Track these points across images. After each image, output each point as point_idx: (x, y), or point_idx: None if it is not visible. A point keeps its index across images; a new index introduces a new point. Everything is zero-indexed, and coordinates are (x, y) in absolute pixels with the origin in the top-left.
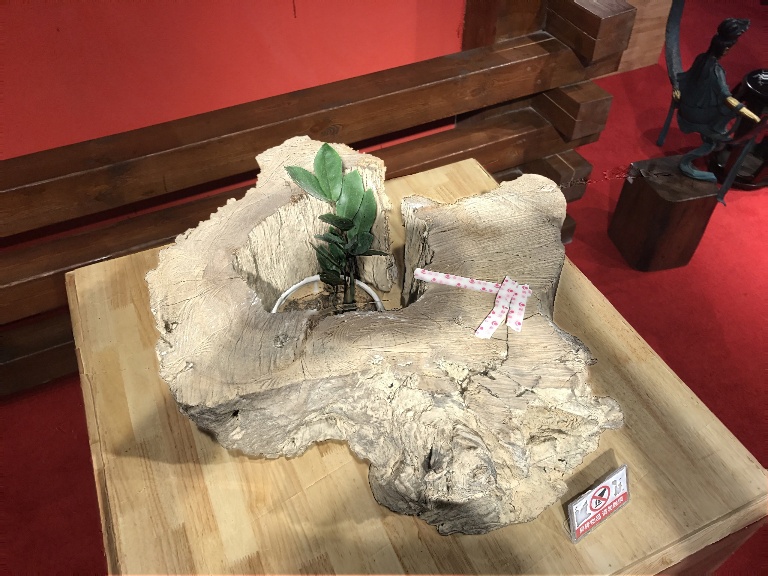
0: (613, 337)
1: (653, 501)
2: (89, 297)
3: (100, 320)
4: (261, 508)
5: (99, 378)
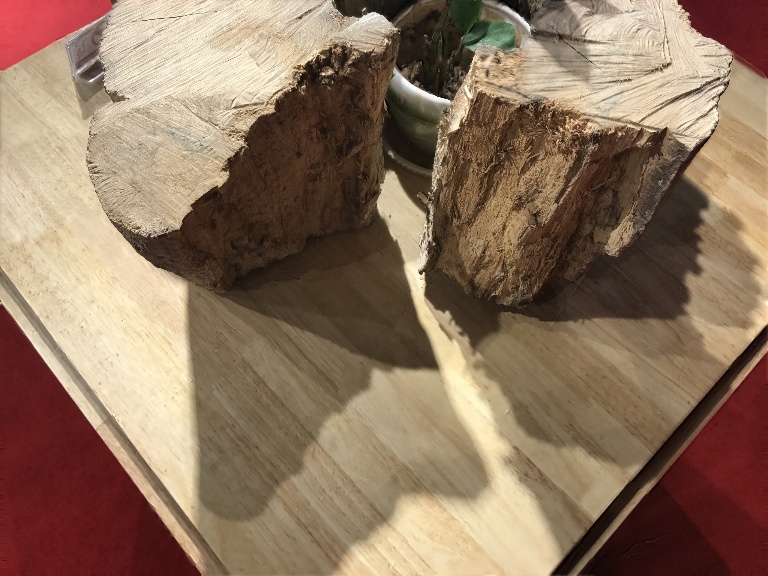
0: (56, 272)
1: (47, 80)
2: None
3: None
4: None
5: None
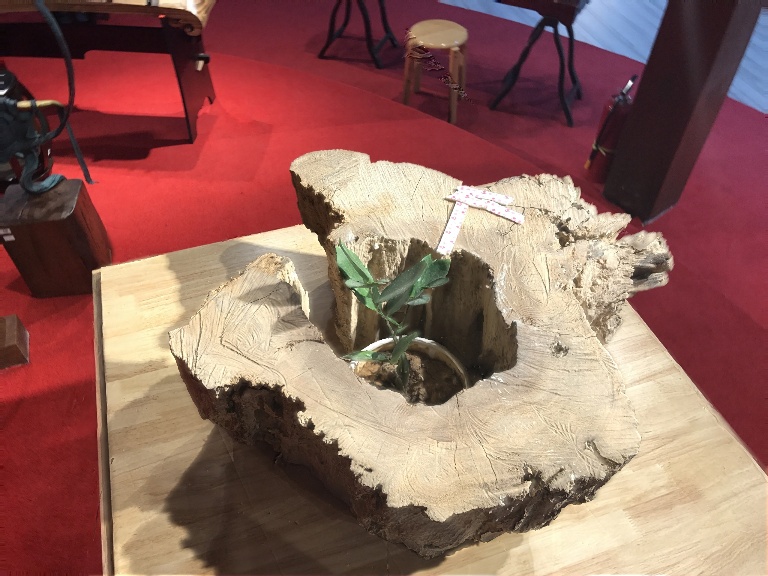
0: None
1: None
2: None
3: None
4: (579, 508)
5: None
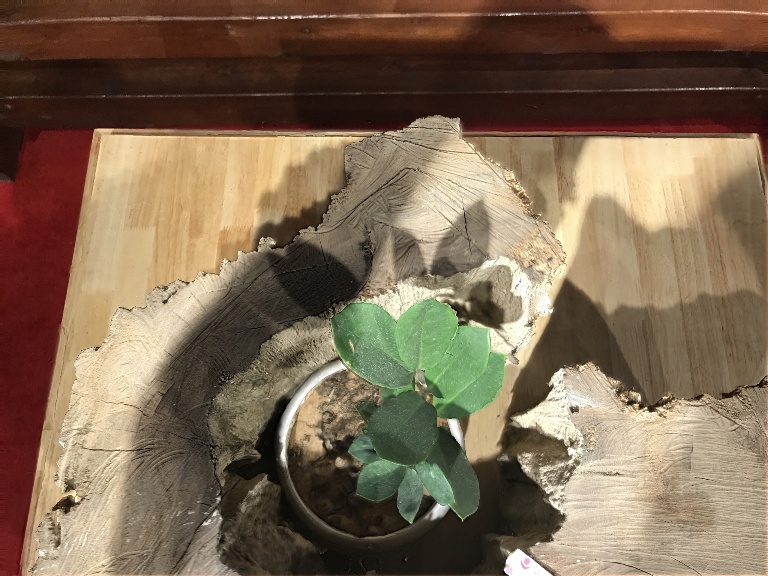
0: None
1: None
2: (107, 192)
3: (108, 238)
4: None
5: (77, 338)
